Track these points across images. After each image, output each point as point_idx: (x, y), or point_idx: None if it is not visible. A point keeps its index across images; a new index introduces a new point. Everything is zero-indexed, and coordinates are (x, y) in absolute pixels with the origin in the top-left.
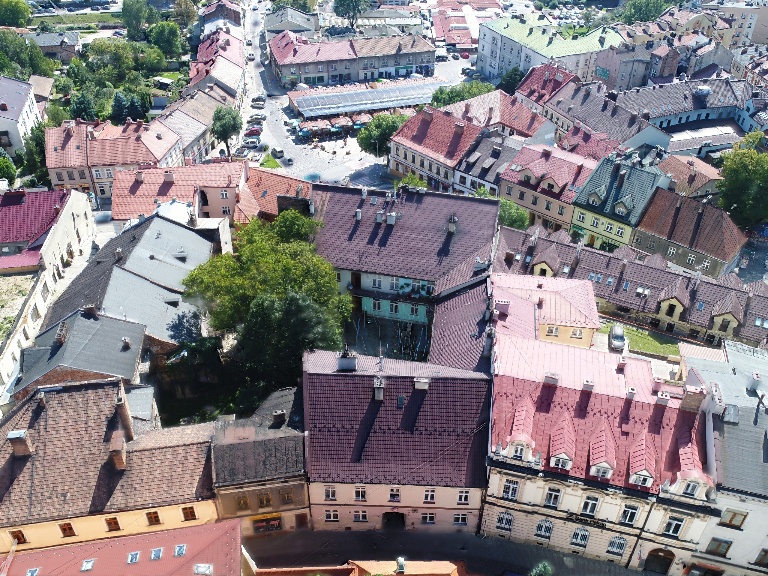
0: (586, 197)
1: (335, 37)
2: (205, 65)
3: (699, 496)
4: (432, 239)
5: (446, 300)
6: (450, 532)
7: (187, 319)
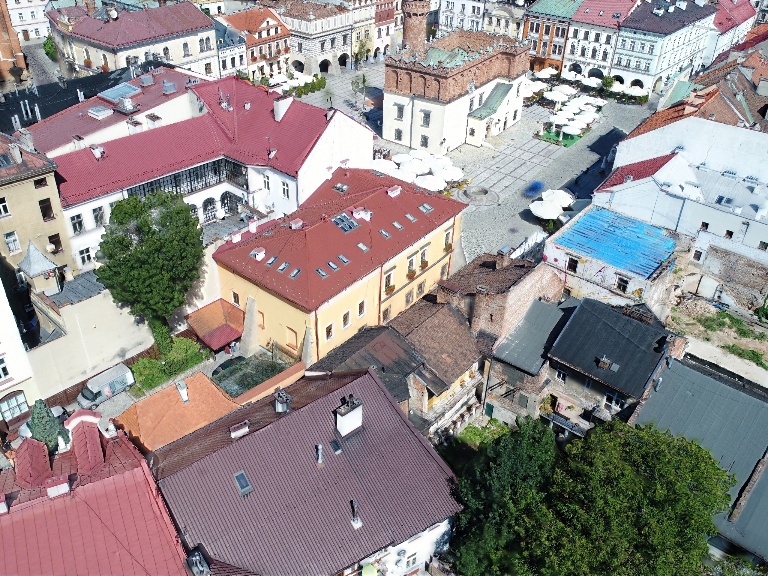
0: None
1: None
2: None
3: None
4: None
5: None
6: None
7: None
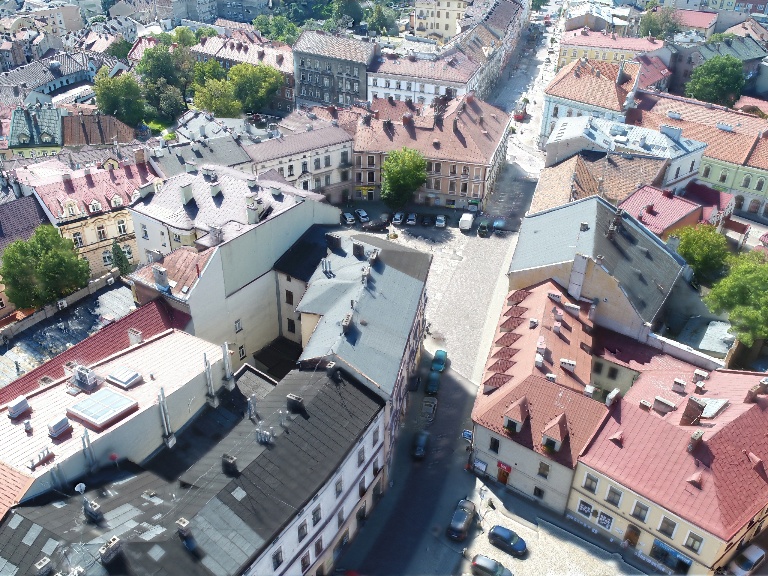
0: (17, 140)
1: None
2: None
3: None
4: None
5: None
6: None
7: None
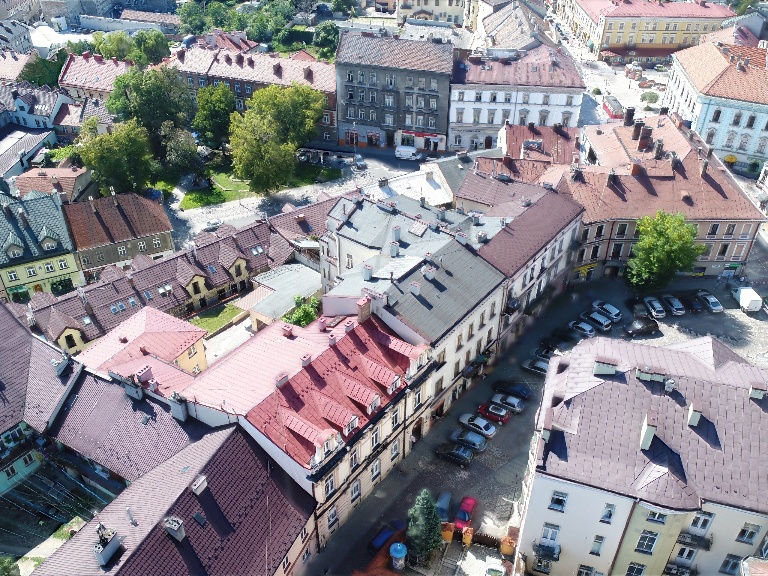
0: (3, 255)
1: None
2: None
3: (425, 362)
4: None
5: (62, 424)
6: (304, 574)
7: None
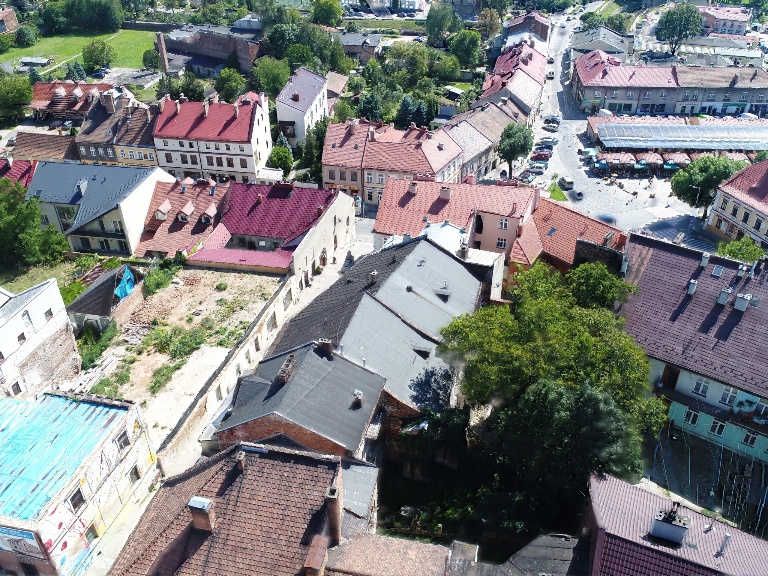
0: None
1: (655, 61)
2: (502, 78)
3: None
4: None
5: None
6: None
7: (436, 378)
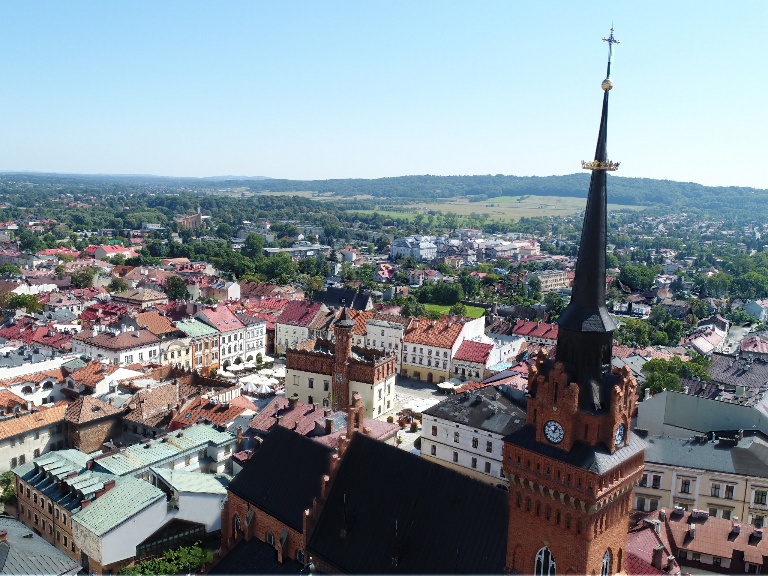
0: None
1: None
2: None
3: None
4: (764, 378)
5: None
6: None
7: (640, 382)
